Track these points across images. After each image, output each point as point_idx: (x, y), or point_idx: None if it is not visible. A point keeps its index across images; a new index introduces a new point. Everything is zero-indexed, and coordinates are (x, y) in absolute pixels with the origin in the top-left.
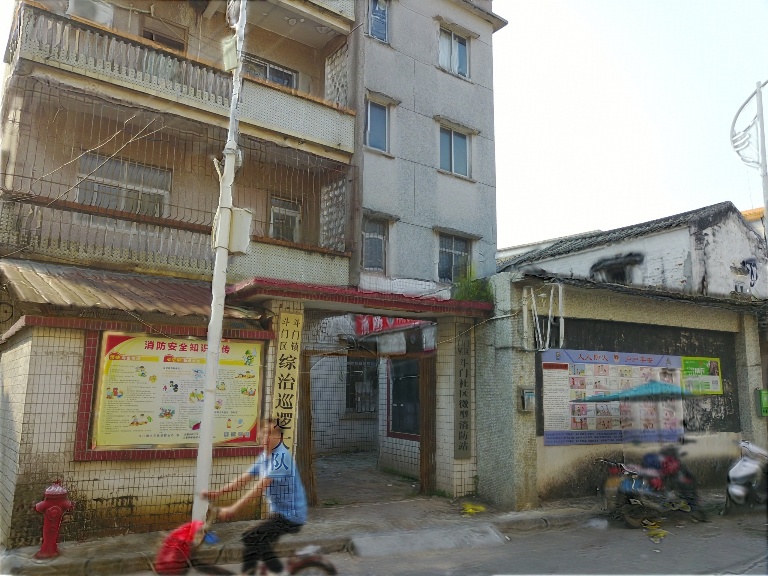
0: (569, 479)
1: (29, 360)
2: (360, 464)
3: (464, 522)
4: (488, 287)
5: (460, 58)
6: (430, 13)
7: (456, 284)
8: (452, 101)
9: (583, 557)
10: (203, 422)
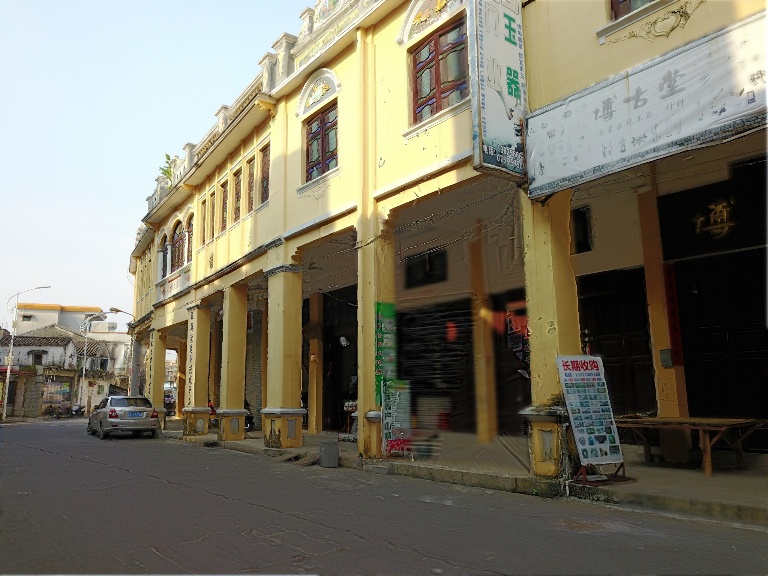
0: None
1: None
2: None
3: None
4: (35, 368)
5: None
6: None
7: None
8: None
9: None
10: None
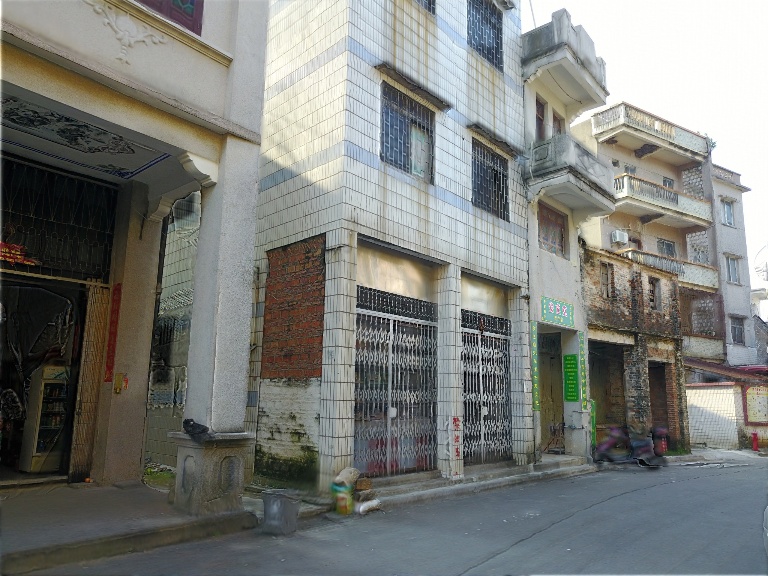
0: None
1: (733, 395)
2: None
3: None
4: None
5: (728, 214)
6: (716, 193)
7: (739, 344)
8: (729, 241)
9: None
10: None
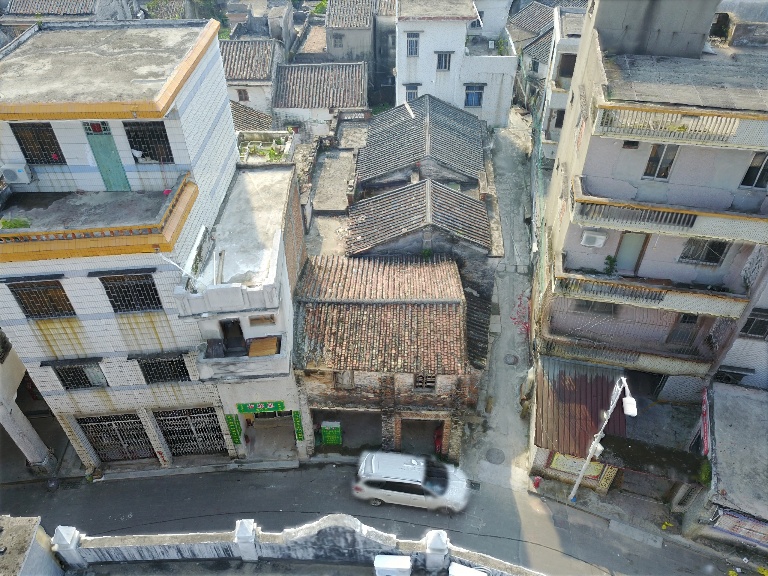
0: (720, 538)
1: (537, 449)
2: (689, 426)
3: (658, 530)
4: None
5: None
6: None
7: None
8: None
9: (674, 572)
10: (577, 481)
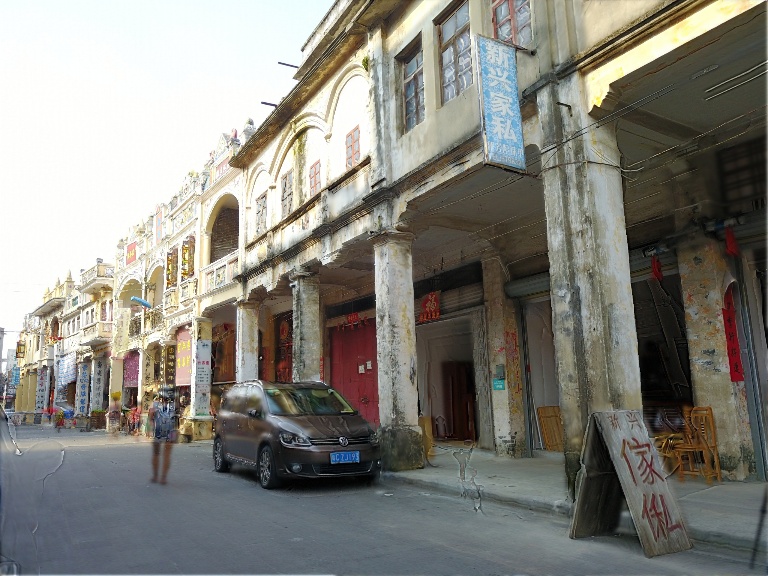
0: None
1: None
2: None
3: None
4: None
5: None
6: None
7: None
8: None
9: None
10: None
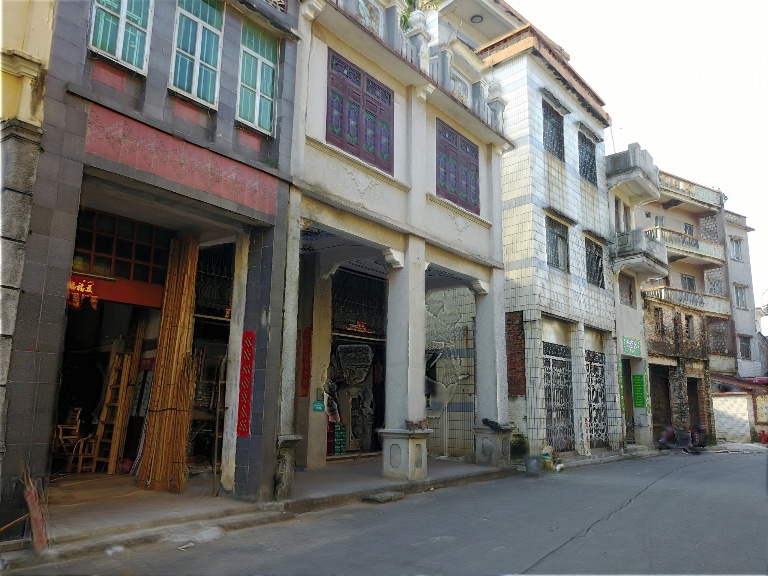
0: None
1: None
2: None
3: None
4: None
5: (736, 250)
6: (727, 234)
7: None
8: (737, 273)
9: None
10: None
